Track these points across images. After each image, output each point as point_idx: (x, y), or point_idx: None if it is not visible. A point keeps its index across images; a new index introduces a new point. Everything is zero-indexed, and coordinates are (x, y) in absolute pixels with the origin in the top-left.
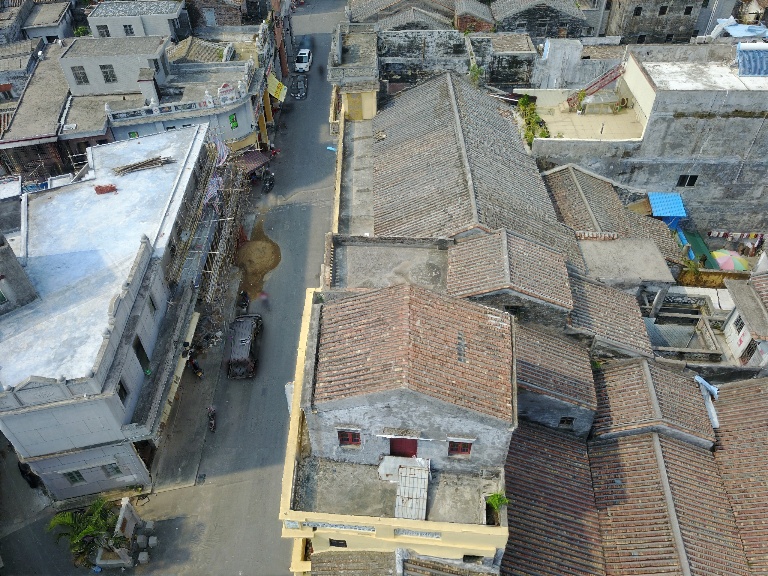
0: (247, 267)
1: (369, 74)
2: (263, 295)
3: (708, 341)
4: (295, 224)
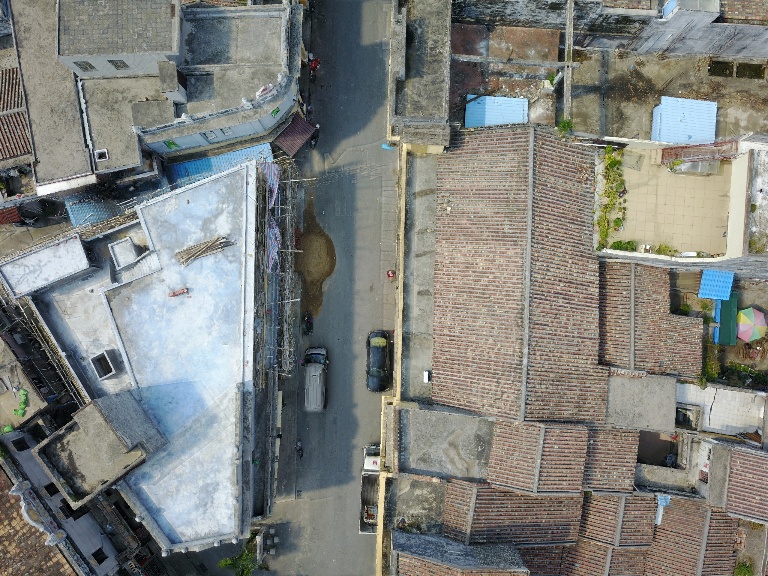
0: (306, 277)
1: (439, 112)
2: (324, 311)
3: (684, 452)
4: (346, 207)
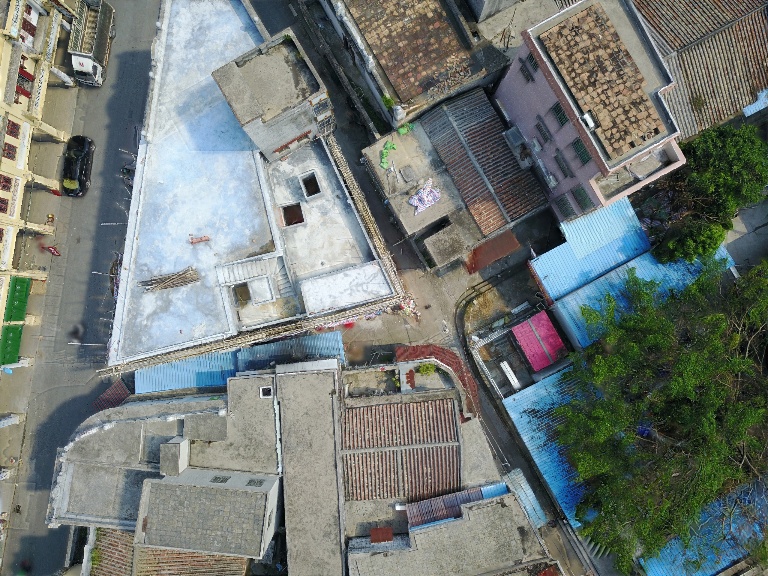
0: None
1: None
2: None
3: None
4: (93, 325)
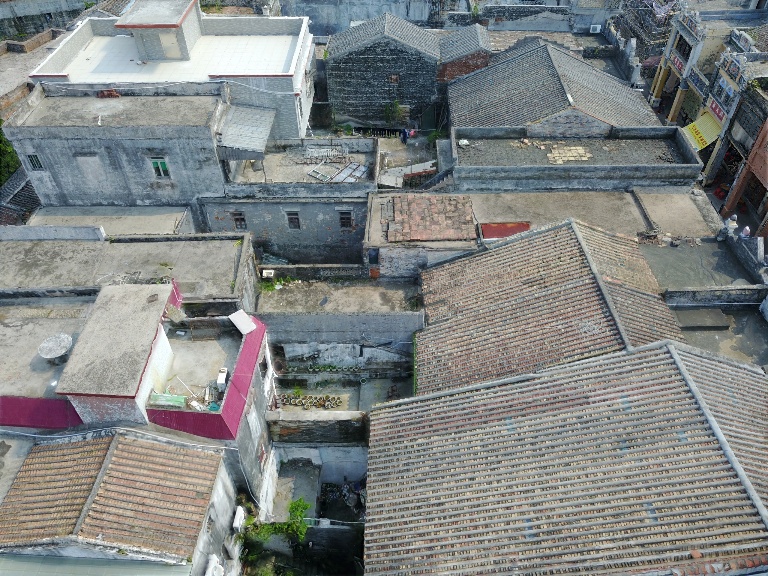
0: None
1: None
2: None
3: None
4: None
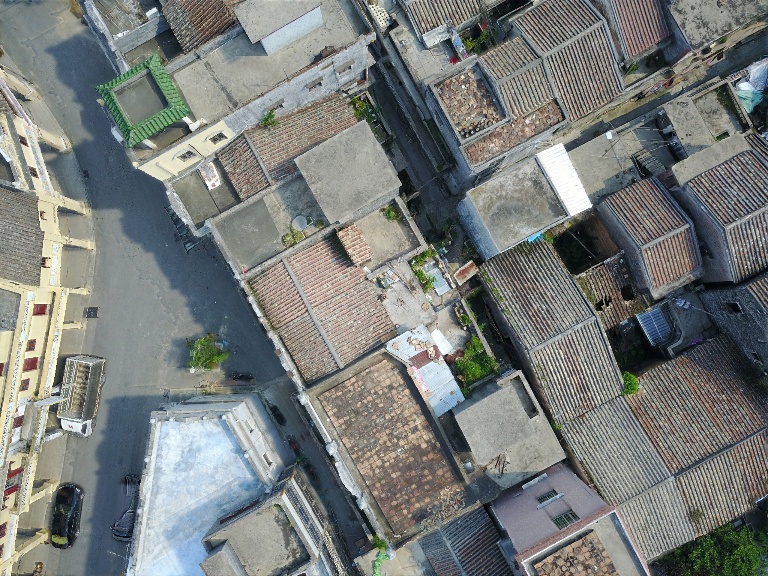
0: None
1: None
2: (118, 572)
3: None
4: None
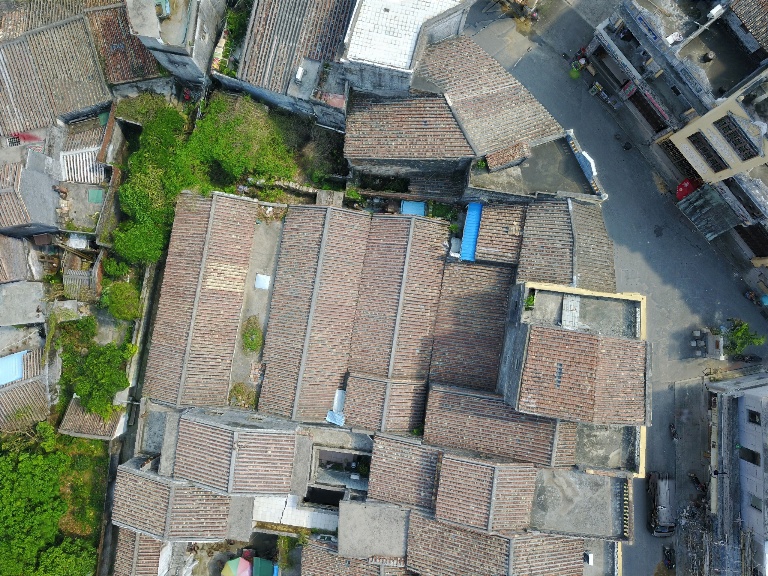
0: None
1: None
2: (652, 569)
3: None
4: None
